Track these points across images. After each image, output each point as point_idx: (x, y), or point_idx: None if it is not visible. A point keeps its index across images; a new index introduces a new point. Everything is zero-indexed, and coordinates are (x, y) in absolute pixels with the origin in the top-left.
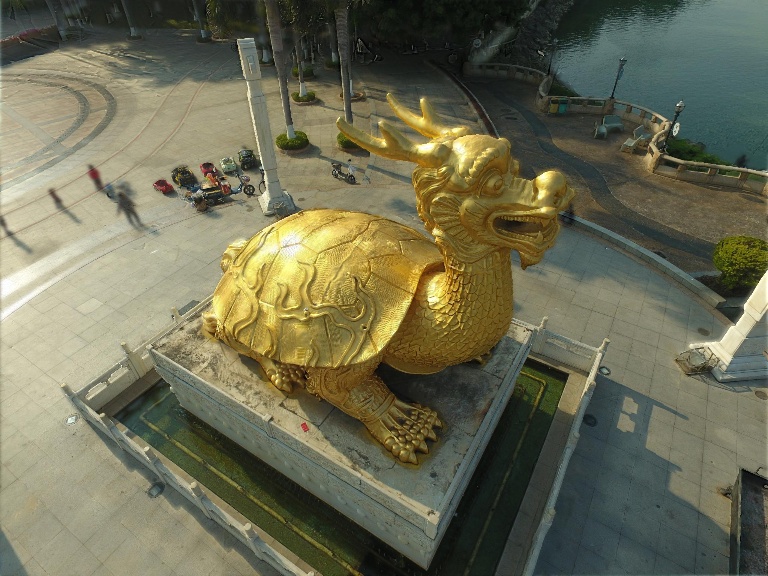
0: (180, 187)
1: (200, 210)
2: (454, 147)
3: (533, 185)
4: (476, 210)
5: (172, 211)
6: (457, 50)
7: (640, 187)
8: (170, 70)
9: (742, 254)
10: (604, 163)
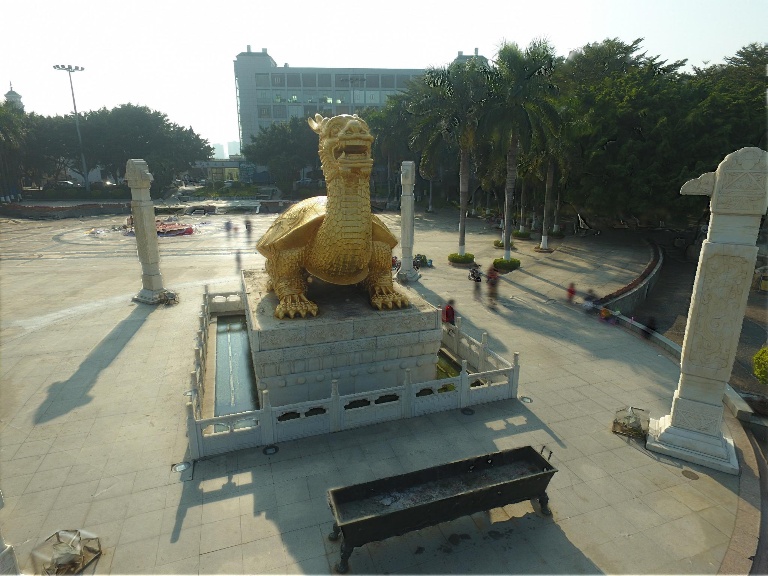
0: None
1: None
2: None
3: None
4: None
5: None
6: (683, 234)
7: None
8: (432, 226)
9: None
10: None
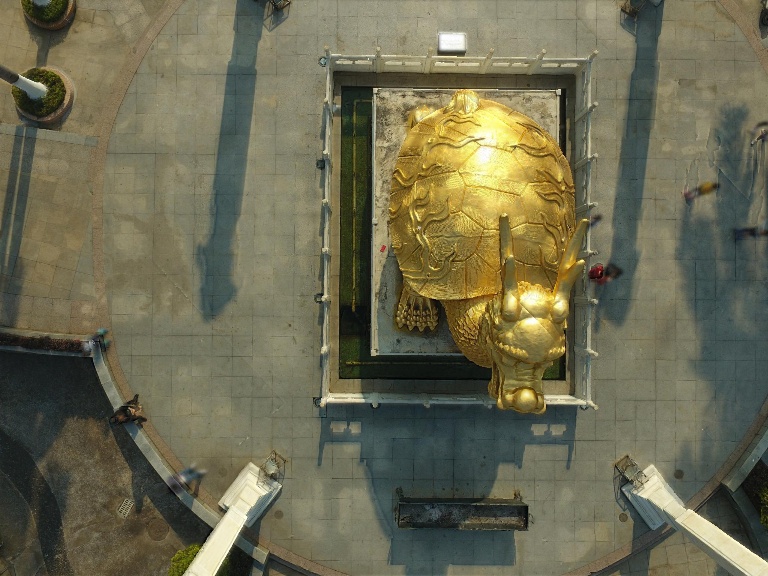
0: None
1: None
2: (522, 321)
3: (520, 387)
4: None
5: None
6: None
7: None
8: None
9: None
10: None
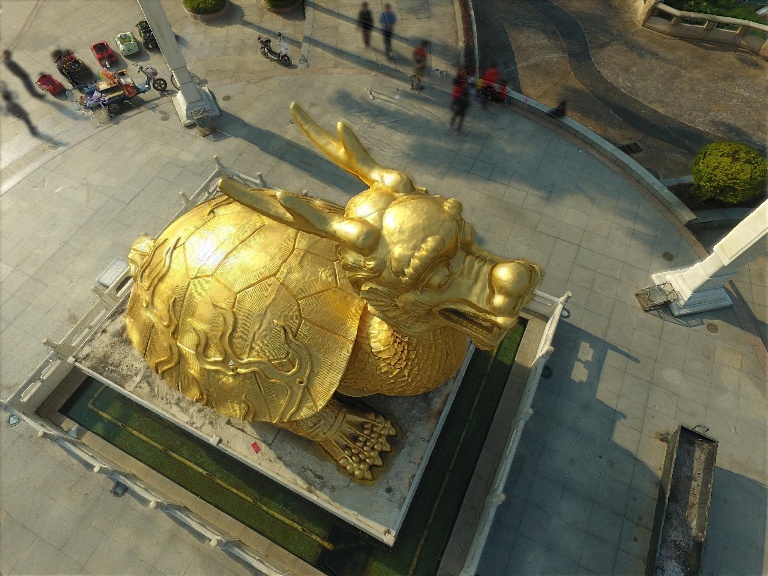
0: (70, 90)
1: (103, 122)
2: (385, 226)
3: (489, 279)
4: (417, 307)
5: (69, 122)
6: None
7: (625, 49)
8: None
9: (724, 170)
10: (588, 13)
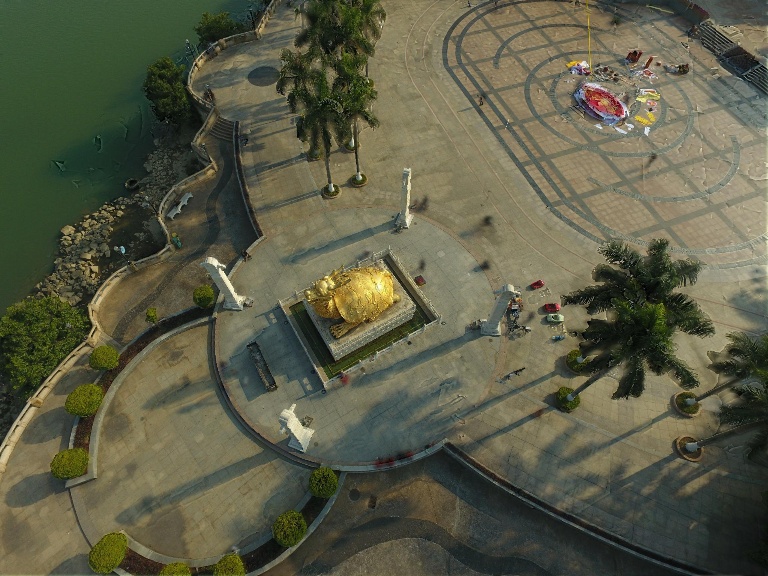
0: None
1: None
2: None
3: None
4: None
5: None
6: None
7: None
8: None
9: (323, 469)
10: None
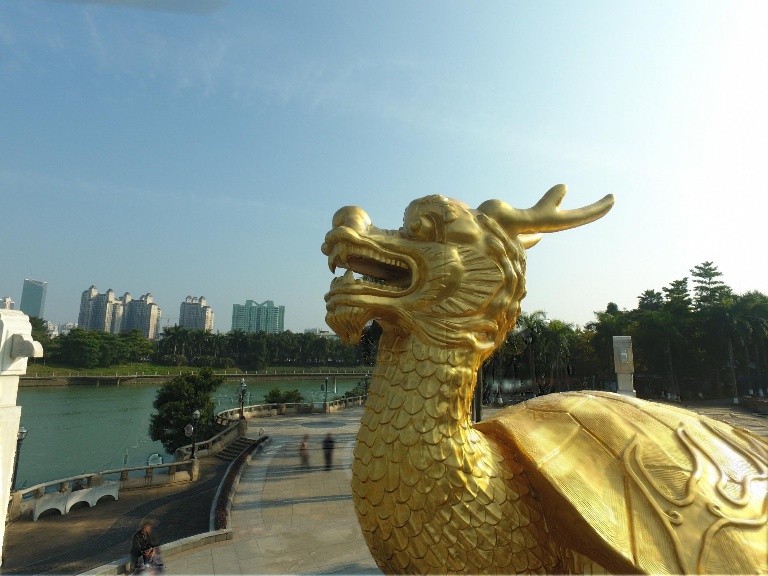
0: None
1: None
2: None
3: None
4: None
5: None
6: None
7: None
8: None
9: None
10: None
